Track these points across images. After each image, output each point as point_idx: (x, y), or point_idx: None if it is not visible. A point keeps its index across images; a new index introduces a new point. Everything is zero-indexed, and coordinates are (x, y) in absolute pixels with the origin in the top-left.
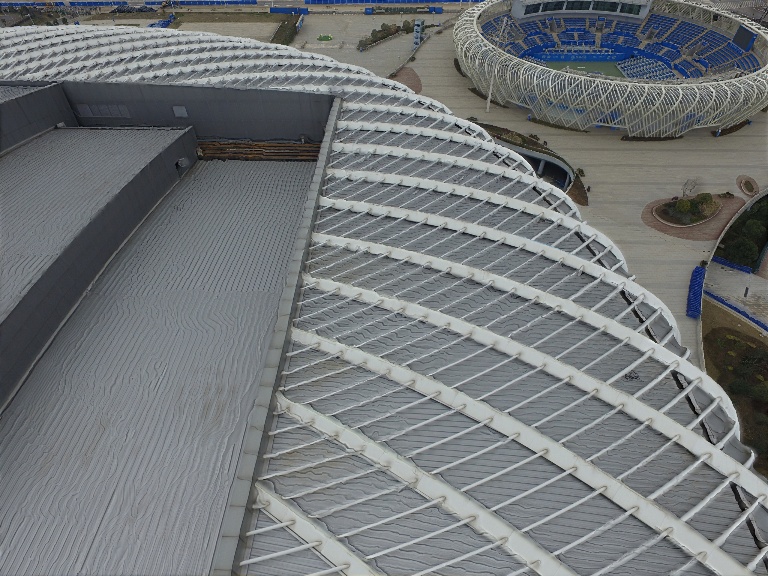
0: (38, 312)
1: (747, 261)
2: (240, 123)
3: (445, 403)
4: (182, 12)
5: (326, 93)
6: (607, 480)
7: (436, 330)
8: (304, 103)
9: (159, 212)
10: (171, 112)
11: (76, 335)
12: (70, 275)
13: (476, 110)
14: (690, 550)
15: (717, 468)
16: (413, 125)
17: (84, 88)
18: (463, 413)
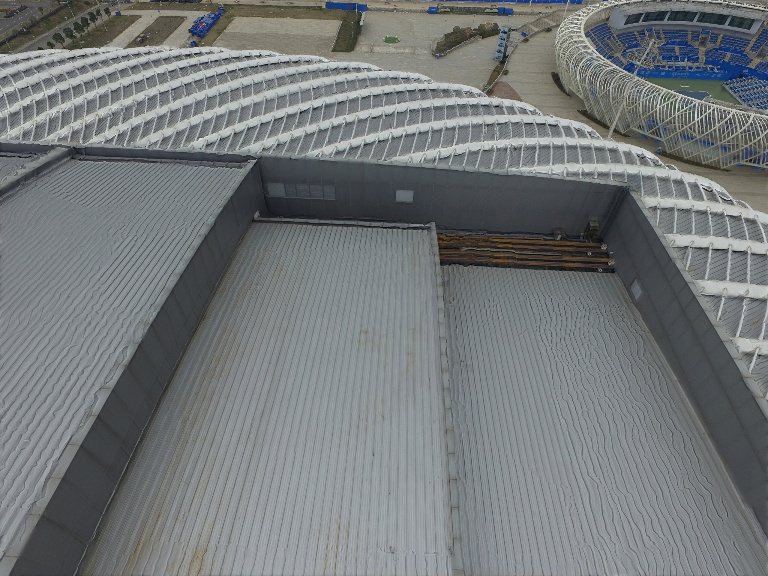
0: None
1: None
2: (480, 212)
3: None
4: (231, 4)
5: (613, 183)
6: None
7: None
8: (579, 194)
9: None
10: (392, 196)
11: None
12: None
13: None
14: None
15: None
16: (748, 237)
17: (287, 165)
18: None
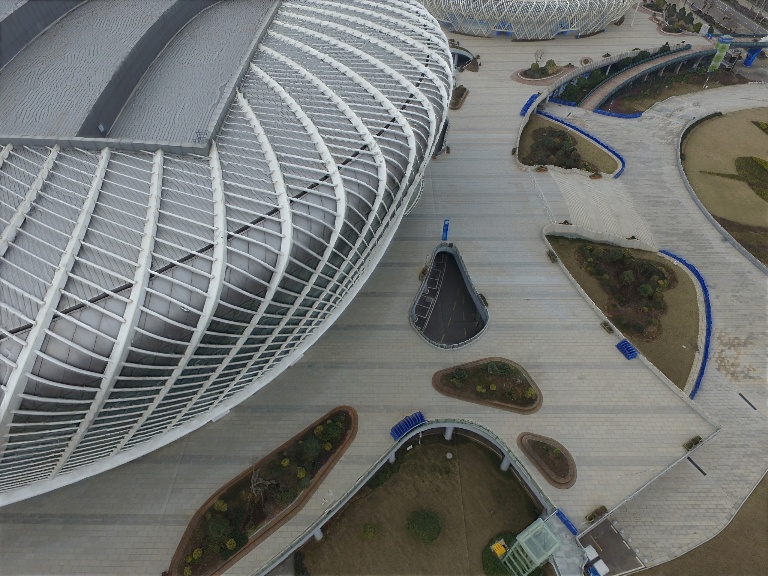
0: (187, 6)
1: (572, 98)
2: None
3: (334, 16)
4: None
5: None
6: (381, 27)
7: (335, 6)
8: None
9: None
10: None
11: (197, 26)
12: (194, 2)
13: None
14: (402, 39)
15: (424, 36)
16: None
17: None
18: None
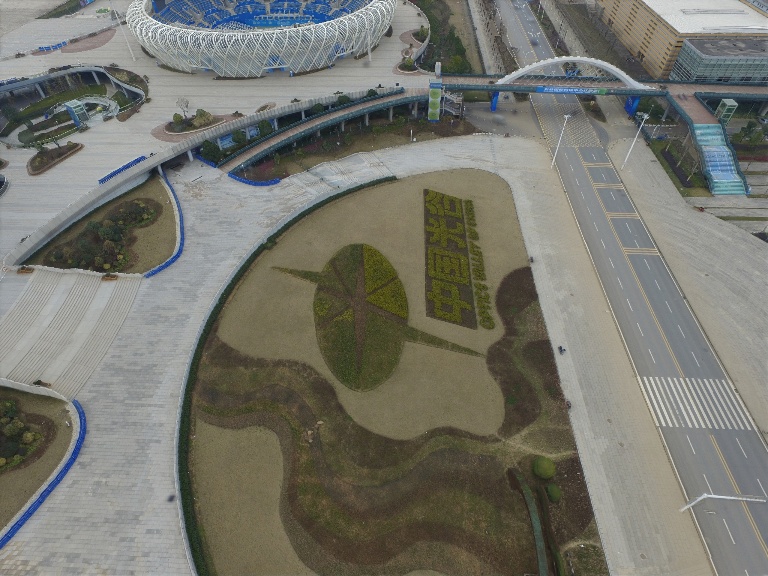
0: None
1: (210, 158)
2: None
3: None
4: None
5: None
6: None
7: None
8: None
9: None
10: None
11: None
12: None
13: (127, 59)
14: None
15: None
16: None
17: None
18: None
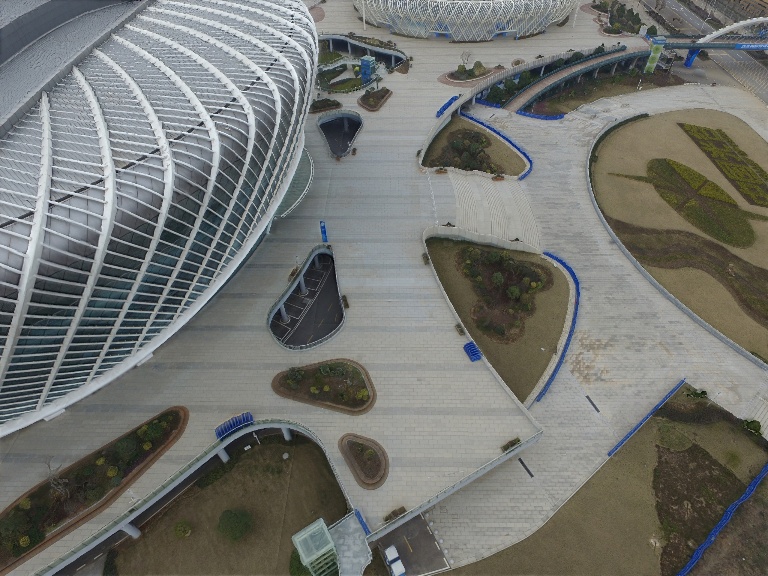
0: (57, 10)
1: (497, 100)
2: None
3: None
4: None
5: None
6: (236, 31)
7: None
8: None
9: (110, 8)
10: None
11: (72, 30)
12: (69, 6)
13: (357, 29)
14: (254, 43)
15: (283, 39)
16: None
17: None
18: (199, 22)
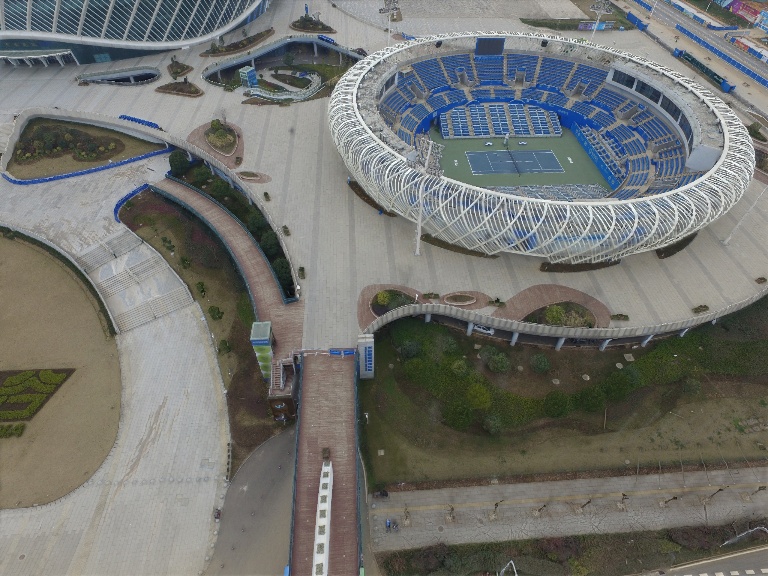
0: None
1: None
2: None
3: None
4: None
5: None
6: None
7: None
8: None
9: None
10: None
11: None
12: None
13: None
14: None
15: None
16: None
17: None
18: None
